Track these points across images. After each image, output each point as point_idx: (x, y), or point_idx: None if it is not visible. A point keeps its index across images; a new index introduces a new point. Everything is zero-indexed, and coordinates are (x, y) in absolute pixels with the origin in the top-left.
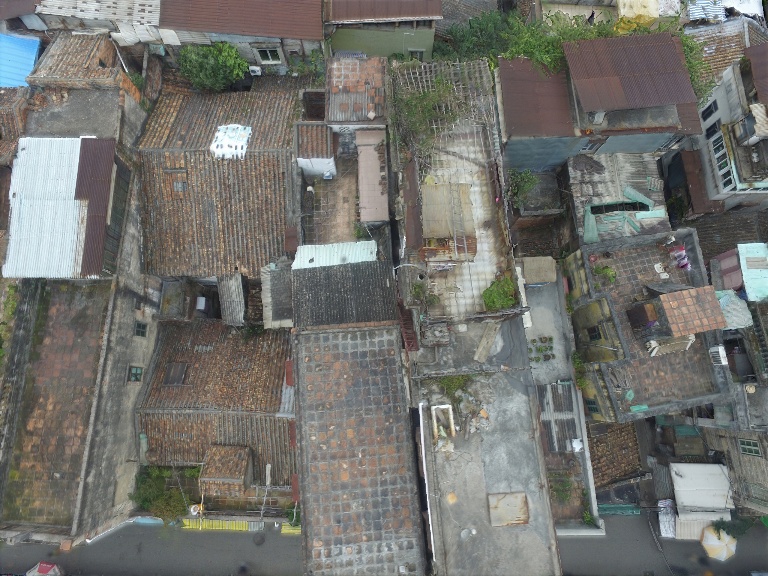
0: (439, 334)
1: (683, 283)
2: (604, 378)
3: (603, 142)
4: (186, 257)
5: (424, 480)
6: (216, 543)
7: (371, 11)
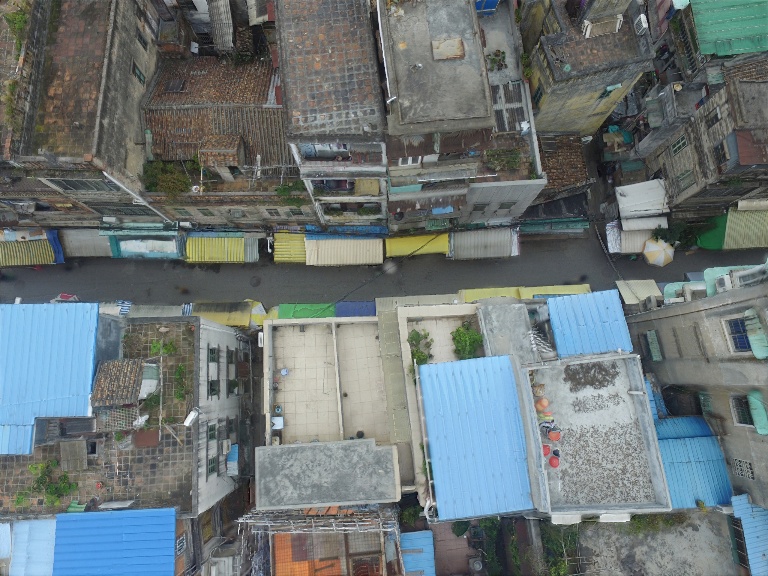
0: None
1: None
2: (543, 47)
3: None
4: None
5: (384, 70)
6: (217, 286)
7: None
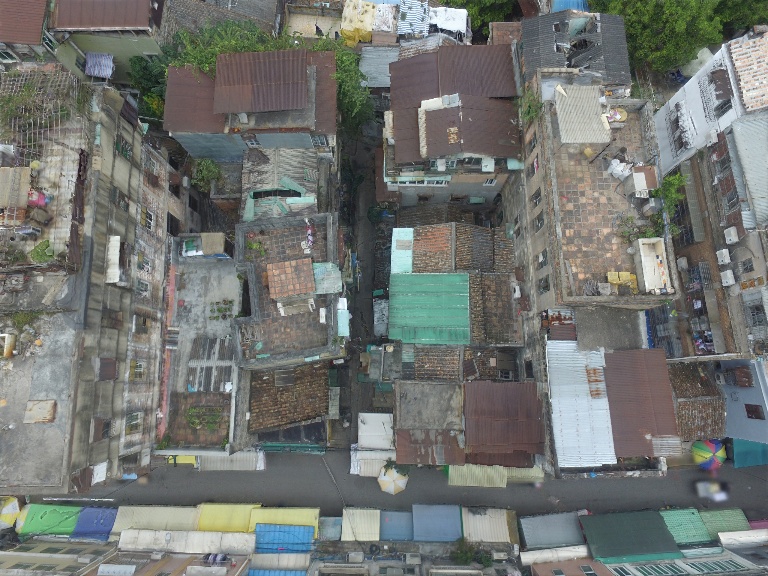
0: (14, 282)
1: (322, 258)
2: None
3: None
4: None
5: None
6: None
7: (90, 21)
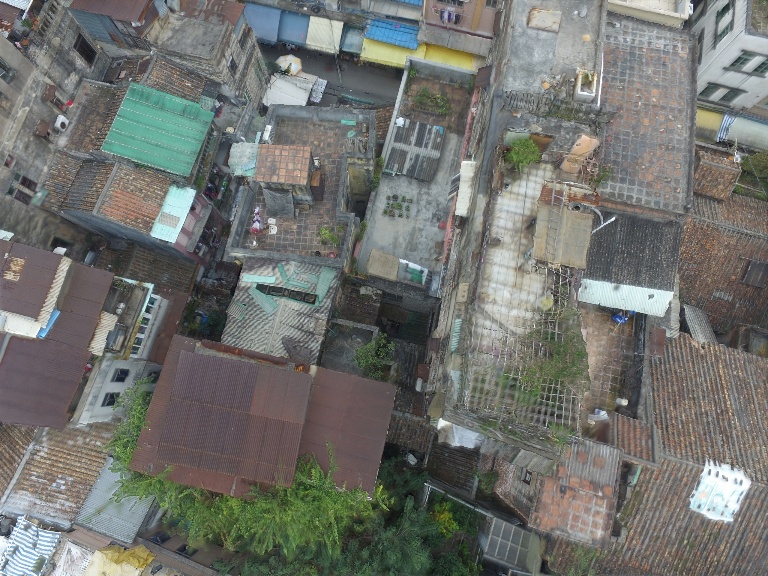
0: None
1: None
2: None
3: None
4: (761, 374)
5: None
6: None
7: None
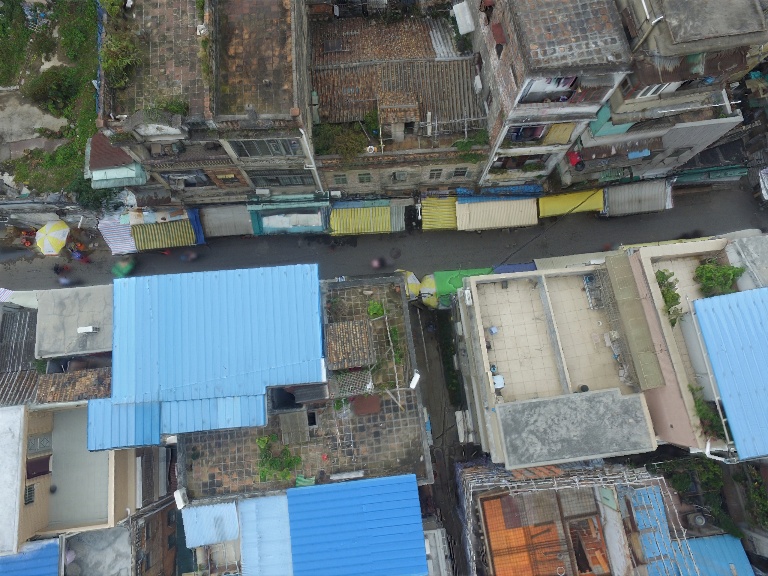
0: None
1: None
2: None
3: None
4: None
5: None
6: (356, 260)
7: None
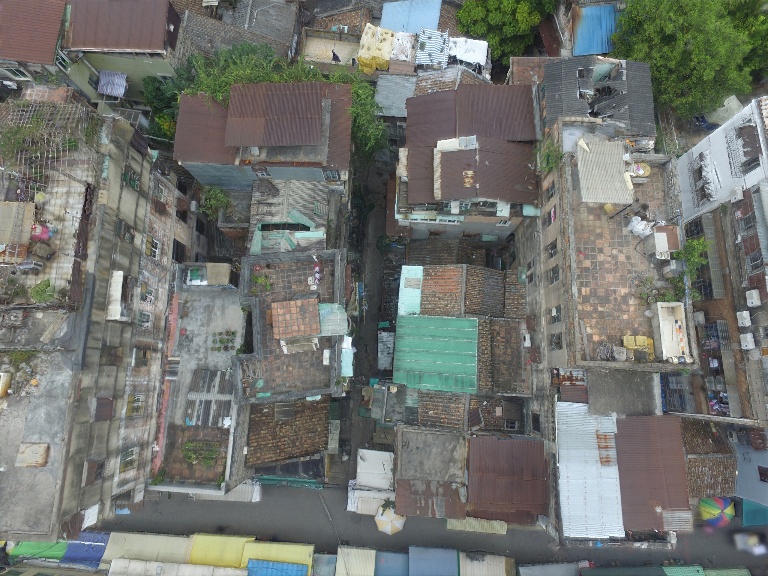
0: (13, 318)
1: (329, 295)
2: None
3: (265, 171)
4: None
5: None
6: None
7: (104, 42)
